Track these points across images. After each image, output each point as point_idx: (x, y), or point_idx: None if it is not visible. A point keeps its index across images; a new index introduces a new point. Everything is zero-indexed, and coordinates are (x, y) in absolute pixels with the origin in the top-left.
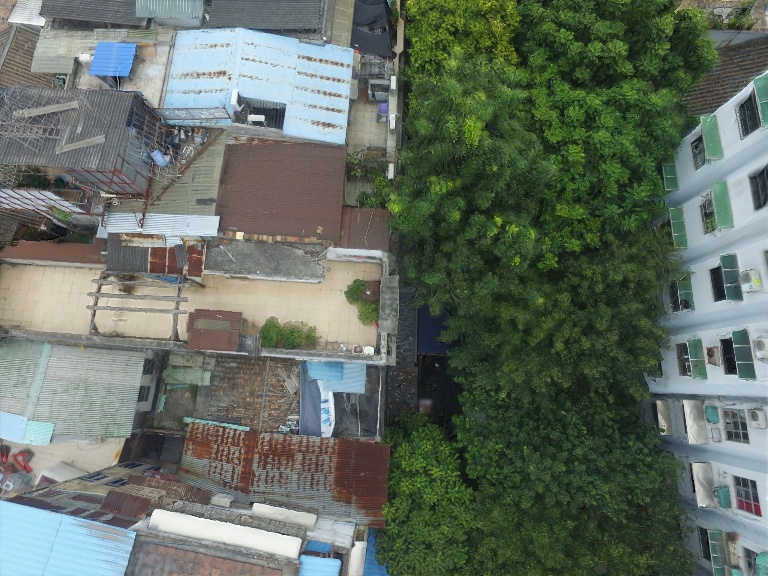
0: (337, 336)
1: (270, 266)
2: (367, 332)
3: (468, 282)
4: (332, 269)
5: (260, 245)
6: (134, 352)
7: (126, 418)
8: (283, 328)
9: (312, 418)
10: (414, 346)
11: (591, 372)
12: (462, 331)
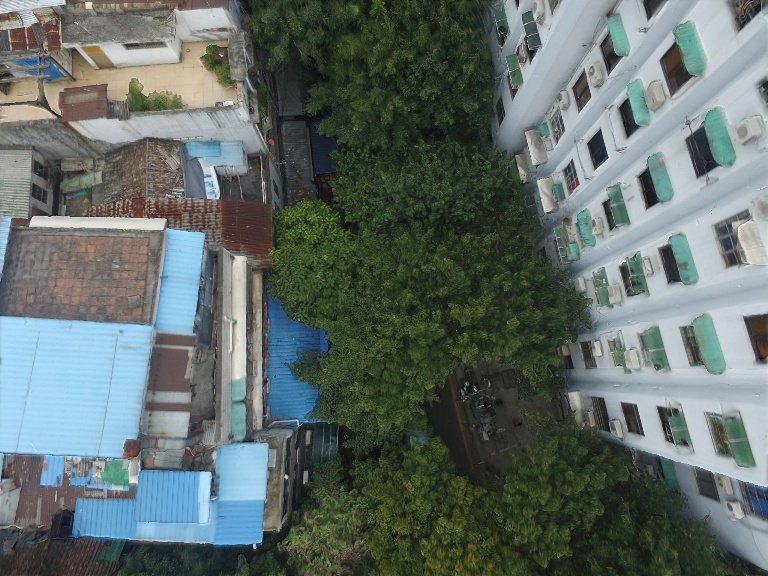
0: (203, 104)
1: (123, 33)
2: (229, 97)
3: (302, 23)
4: (191, 50)
5: (112, 17)
6: (21, 151)
7: (22, 206)
8: (149, 97)
9: (197, 191)
10: (310, 167)
11: (426, 94)
12: (324, 101)
